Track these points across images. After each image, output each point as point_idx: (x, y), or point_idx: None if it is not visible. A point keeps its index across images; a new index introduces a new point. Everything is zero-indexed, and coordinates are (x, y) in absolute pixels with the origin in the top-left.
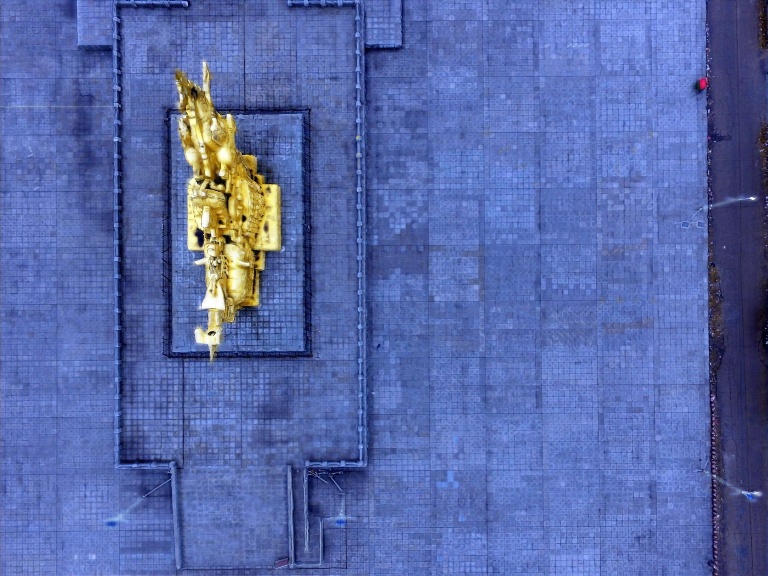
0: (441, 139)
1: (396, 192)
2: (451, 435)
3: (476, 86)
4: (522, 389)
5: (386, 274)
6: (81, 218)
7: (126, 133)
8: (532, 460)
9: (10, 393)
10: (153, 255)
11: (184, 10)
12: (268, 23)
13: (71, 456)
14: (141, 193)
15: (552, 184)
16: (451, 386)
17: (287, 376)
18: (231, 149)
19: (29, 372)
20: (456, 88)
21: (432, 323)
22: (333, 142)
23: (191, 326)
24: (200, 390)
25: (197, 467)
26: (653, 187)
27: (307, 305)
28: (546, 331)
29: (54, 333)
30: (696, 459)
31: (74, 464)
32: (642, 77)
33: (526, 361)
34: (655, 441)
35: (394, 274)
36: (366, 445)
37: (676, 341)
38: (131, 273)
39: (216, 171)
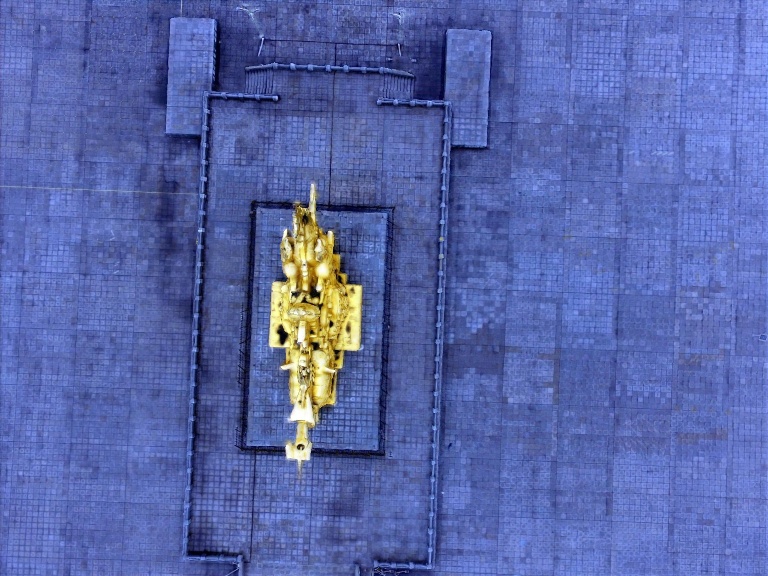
0: (521, 241)
1: (474, 291)
2: (519, 539)
3: (559, 189)
4: (593, 496)
5: (461, 373)
6: (159, 303)
7: (210, 223)
8: (600, 568)
9: (79, 476)
10: (231, 346)
11: (273, 104)
12: (356, 120)
13: (137, 542)
14: (222, 283)
15: (631, 291)
16: (521, 489)
17: (359, 473)
18: (329, 264)
19: (99, 455)
20: (539, 190)
21: (505, 425)
22: (415, 241)
23: (266, 420)
24: (271, 484)
25: (264, 561)
26: (732, 298)
27: (382, 403)
28: (619, 438)
29: (126, 417)
30: (766, 575)
31: (140, 550)
32: (725, 188)
33: (598, 467)
34: (725, 555)
35: (469, 373)
36: (435, 547)
37: (750, 454)
38: (208, 363)
39: (312, 284)
